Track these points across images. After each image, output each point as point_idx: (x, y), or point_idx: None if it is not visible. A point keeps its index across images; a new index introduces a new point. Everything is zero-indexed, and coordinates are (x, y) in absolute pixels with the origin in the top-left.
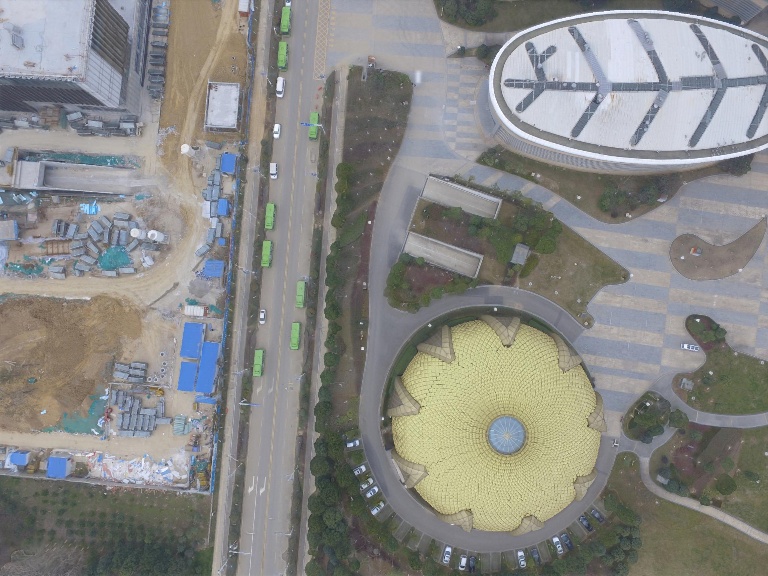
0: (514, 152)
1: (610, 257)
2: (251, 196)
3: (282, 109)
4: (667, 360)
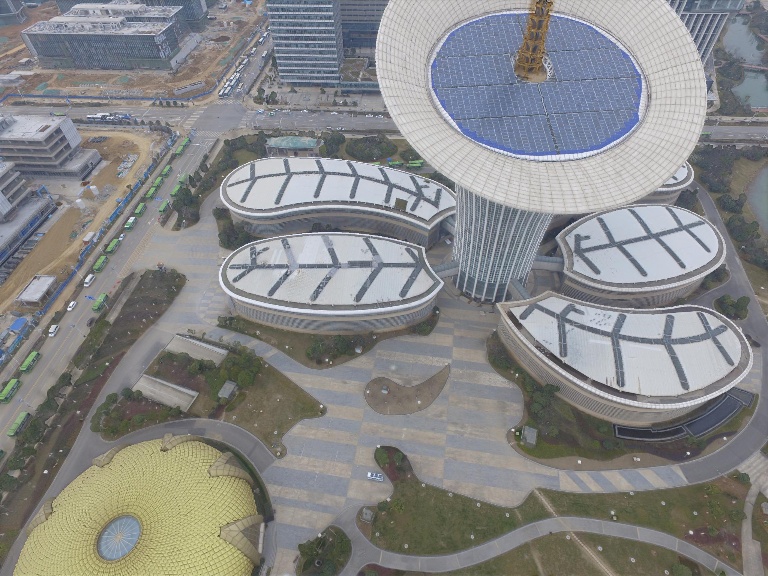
0: (249, 320)
1: (311, 395)
2: (26, 349)
3: (84, 294)
4: (354, 491)
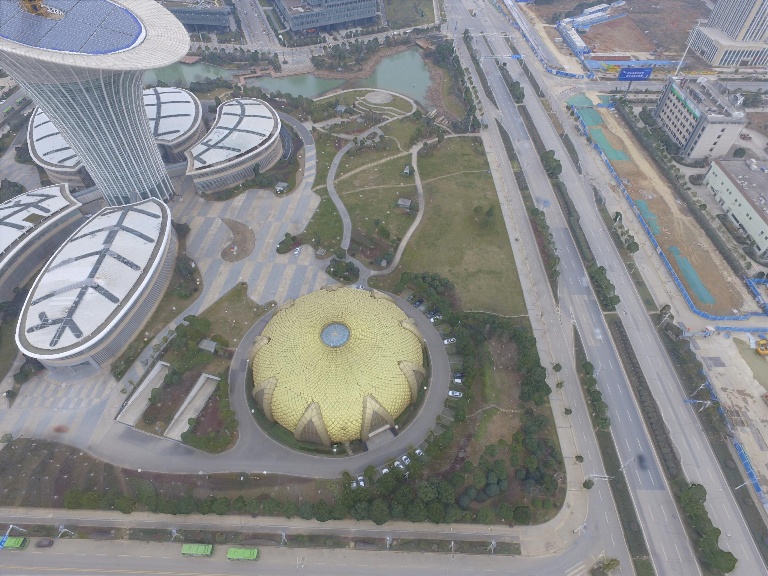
0: (122, 354)
1: (226, 292)
2: None
3: None
4: (305, 262)
